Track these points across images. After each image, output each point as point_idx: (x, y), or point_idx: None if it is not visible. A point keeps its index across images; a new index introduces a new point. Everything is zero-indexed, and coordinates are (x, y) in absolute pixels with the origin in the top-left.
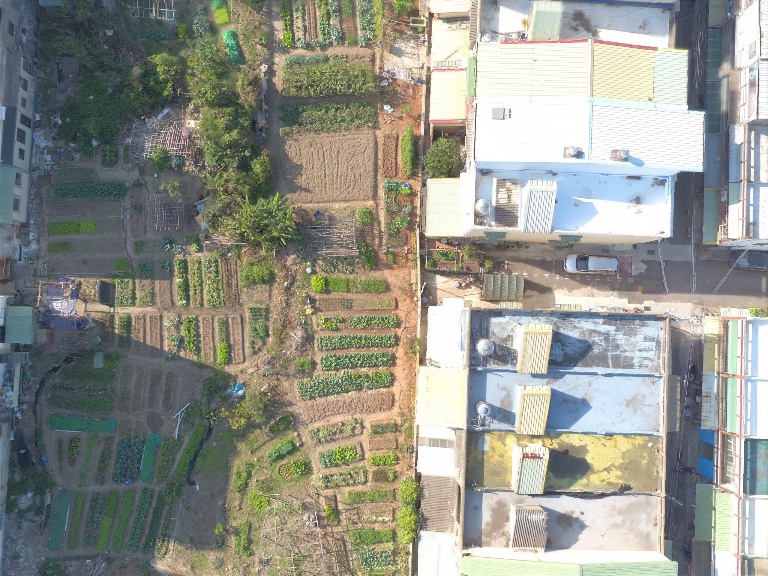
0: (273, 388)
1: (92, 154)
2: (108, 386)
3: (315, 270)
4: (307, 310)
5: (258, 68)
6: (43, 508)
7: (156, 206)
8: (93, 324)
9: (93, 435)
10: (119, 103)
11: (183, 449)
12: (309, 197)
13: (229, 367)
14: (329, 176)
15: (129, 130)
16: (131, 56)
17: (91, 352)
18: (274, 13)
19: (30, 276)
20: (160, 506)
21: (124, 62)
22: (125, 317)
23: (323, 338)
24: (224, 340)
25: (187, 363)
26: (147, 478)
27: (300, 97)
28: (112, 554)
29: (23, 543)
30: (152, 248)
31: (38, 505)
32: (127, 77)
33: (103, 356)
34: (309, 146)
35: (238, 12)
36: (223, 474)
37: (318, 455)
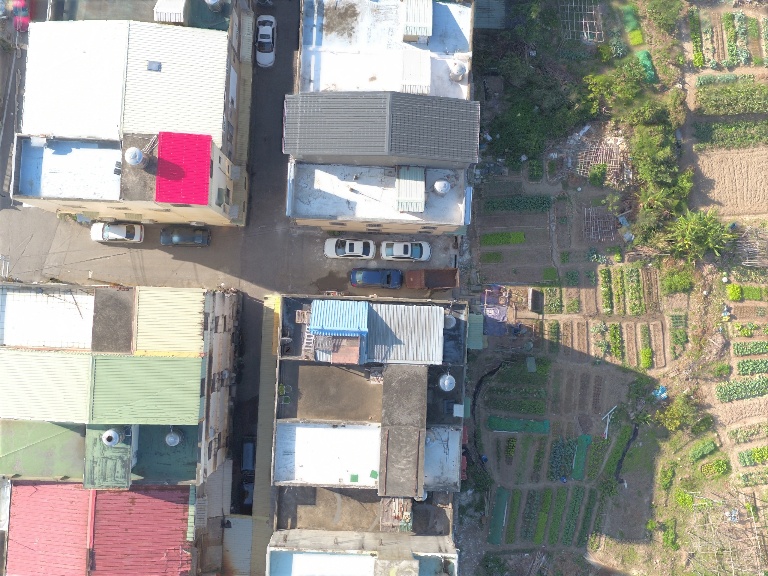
0: (694, 391)
1: (519, 169)
2: (542, 389)
3: (729, 279)
4: (724, 317)
5: (672, 87)
6: (483, 504)
7: (591, 219)
8: (524, 330)
9: (528, 435)
10: (547, 120)
11: (611, 449)
12: (722, 210)
13: (651, 371)
14: (740, 190)
15: (553, 146)
16: (558, 76)
17: (523, 357)
18: (684, 35)
19: (465, 285)
20: (593, 503)
21: (553, 82)
22: (555, 324)
23: (739, 344)
24: (647, 346)
25: (612, 367)
26: (579, 476)
27: (714, 115)
28: (548, 548)
29: (464, 537)
30: (577, 258)
31: (478, 502)
32: (562, 96)
33: (535, 361)
34: (720, 162)
35: (651, 34)
36: (648, 473)
37: (737, 455)
